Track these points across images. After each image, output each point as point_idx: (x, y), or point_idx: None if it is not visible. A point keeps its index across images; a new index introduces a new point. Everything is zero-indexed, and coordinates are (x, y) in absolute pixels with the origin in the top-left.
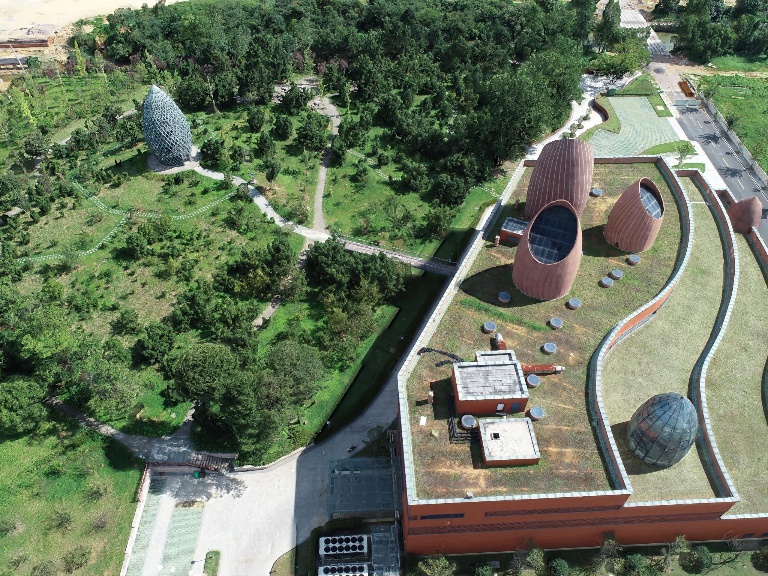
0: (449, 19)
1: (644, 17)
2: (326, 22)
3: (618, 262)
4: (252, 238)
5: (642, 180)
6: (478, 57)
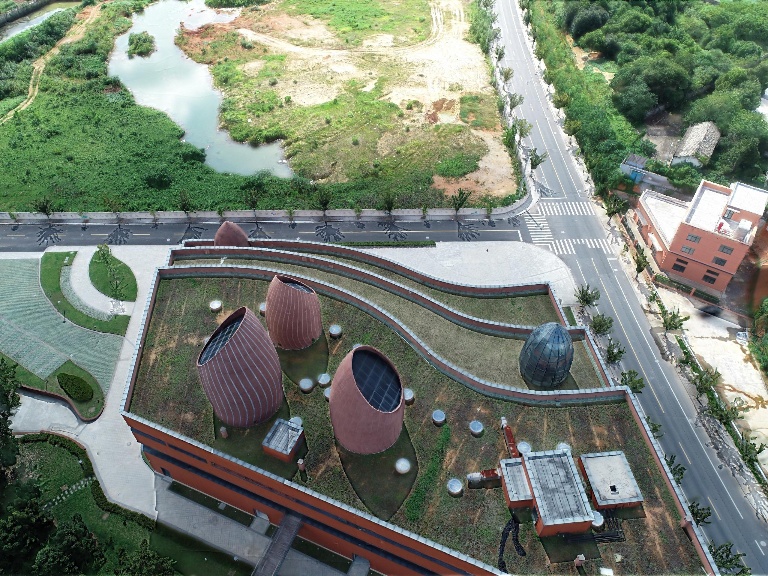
0: None
1: None
2: None
3: (337, 346)
4: None
5: None
6: None
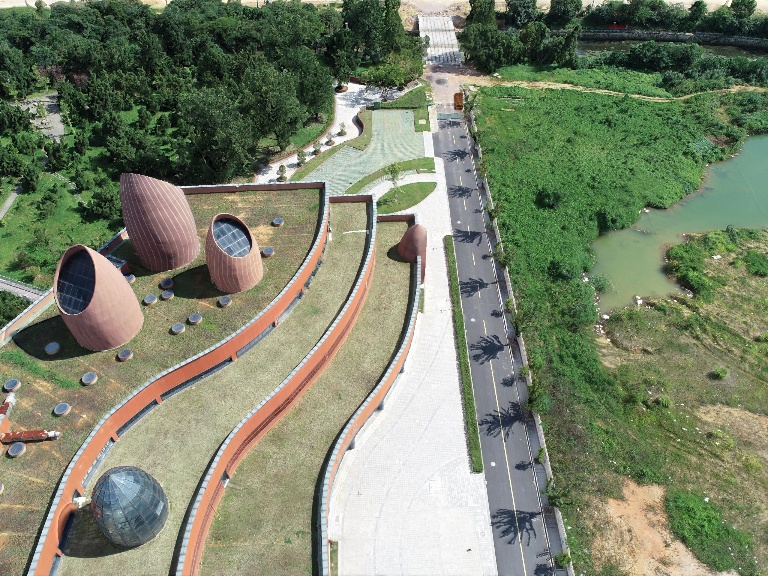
0: (243, 28)
1: (457, 24)
2: (106, 33)
3: (208, 304)
4: None
5: (223, 216)
6: (239, 70)
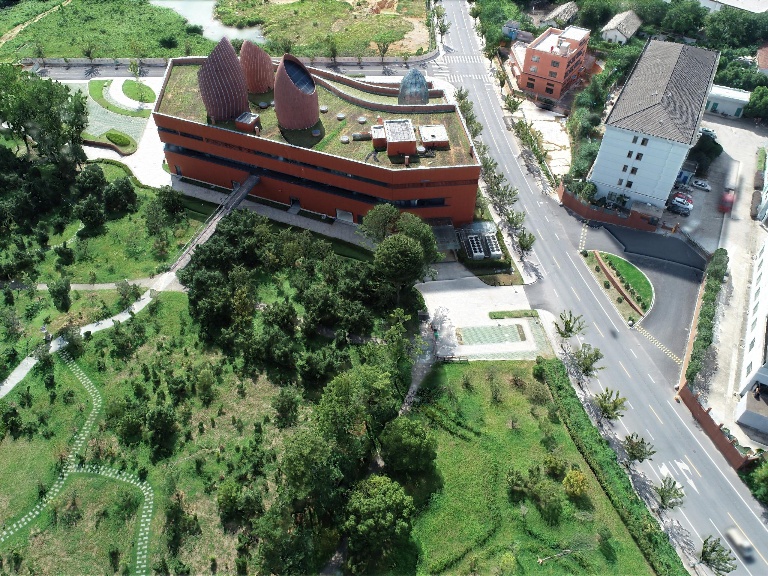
0: None
1: None
2: None
3: None
4: (156, 330)
5: None
6: None
